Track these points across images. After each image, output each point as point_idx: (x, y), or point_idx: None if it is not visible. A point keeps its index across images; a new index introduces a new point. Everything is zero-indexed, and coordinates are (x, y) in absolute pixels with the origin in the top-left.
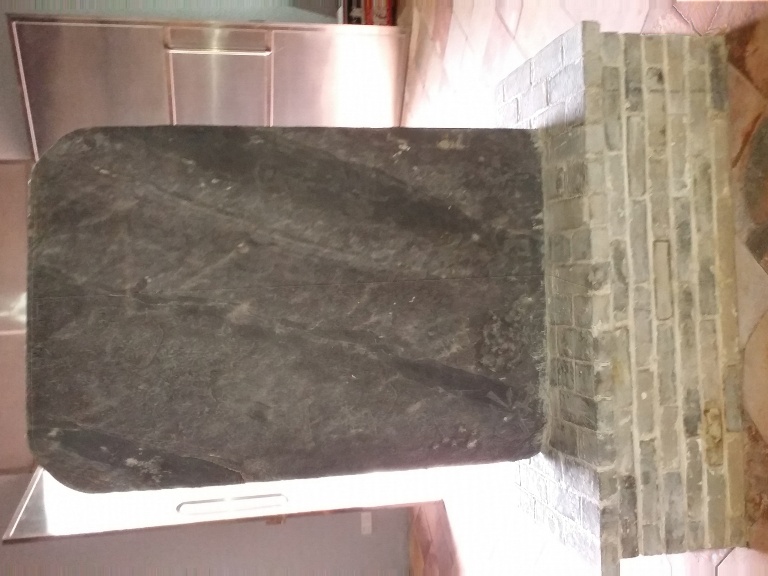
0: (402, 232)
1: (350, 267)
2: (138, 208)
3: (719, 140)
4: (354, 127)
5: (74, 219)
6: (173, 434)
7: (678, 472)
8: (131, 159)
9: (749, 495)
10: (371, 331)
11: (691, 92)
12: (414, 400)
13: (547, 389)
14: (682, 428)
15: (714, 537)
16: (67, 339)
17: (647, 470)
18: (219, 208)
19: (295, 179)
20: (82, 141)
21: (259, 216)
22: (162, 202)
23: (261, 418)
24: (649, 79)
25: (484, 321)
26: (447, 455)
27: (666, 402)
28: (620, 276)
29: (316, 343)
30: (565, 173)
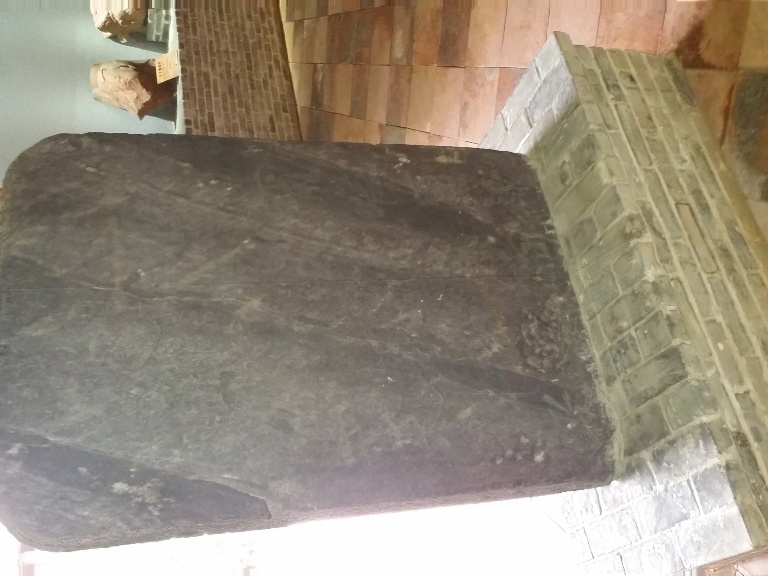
0: (416, 233)
1: (368, 265)
2: (129, 204)
3: (700, 127)
4: None
5: (55, 211)
6: (175, 450)
7: None
8: (121, 160)
9: None
10: (401, 329)
11: (662, 91)
12: (463, 405)
13: (605, 392)
14: None
15: None
16: (40, 335)
17: (754, 426)
18: (220, 206)
19: (298, 183)
20: (67, 142)
21: (264, 215)
22: (156, 199)
23: (286, 428)
24: (623, 79)
25: (520, 320)
26: (514, 471)
27: (745, 353)
28: (655, 232)
29: (341, 342)
30: (569, 161)
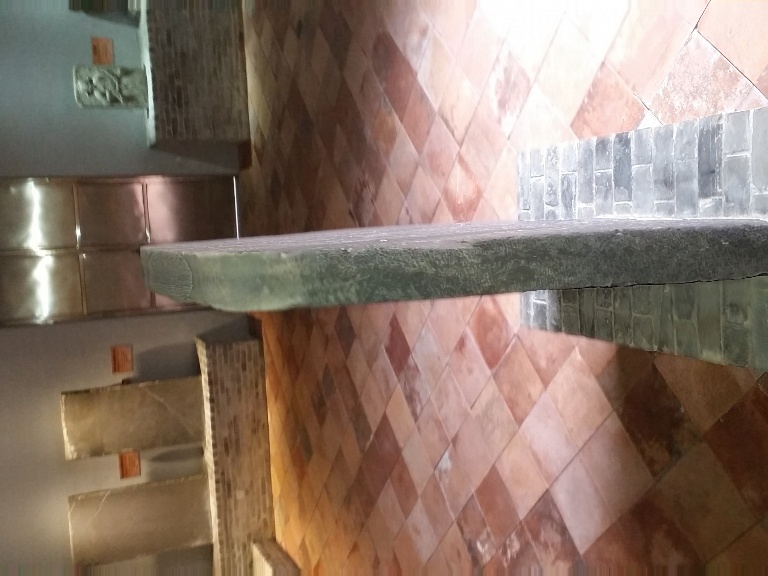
0: None
1: None
2: None
3: None
4: (614, 286)
5: None
6: None
7: None
8: None
9: None
10: None
11: None
12: None
13: None
14: None
15: None
16: None
17: None
18: None
19: None
20: None
21: None
22: None
23: None
24: None
25: None
26: None
27: None
28: None
29: None
30: (742, 326)
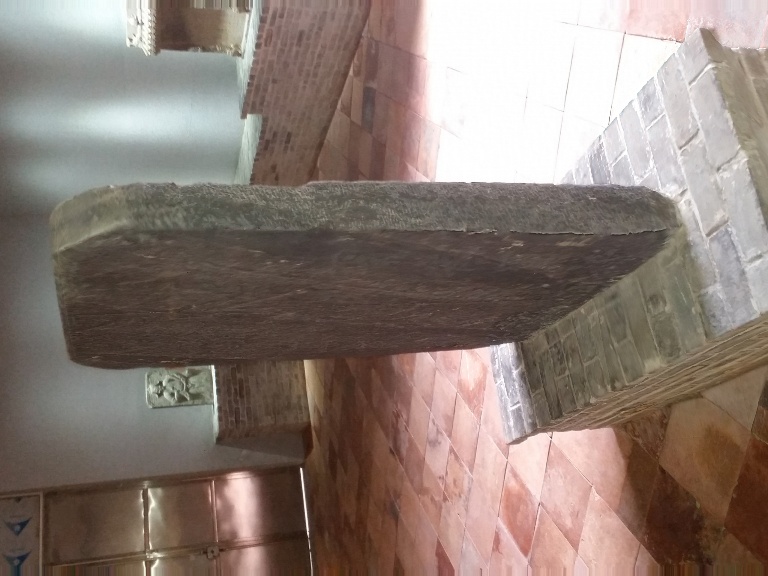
0: (474, 284)
1: (407, 298)
2: (189, 274)
3: None
4: (470, 231)
5: (112, 282)
6: None
7: None
8: (185, 249)
9: (635, 424)
10: (407, 319)
11: None
12: None
13: (540, 332)
14: None
15: None
16: (106, 329)
17: None
18: (283, 274)
19: (379, 259)
20: (121, 239)
21: (327, 277)
22: (218, 272)
23: None
24: None
25: (515, 314)
26: (434, 349)
27: None
28: None
29: (351, 324)
30: (664, 313)
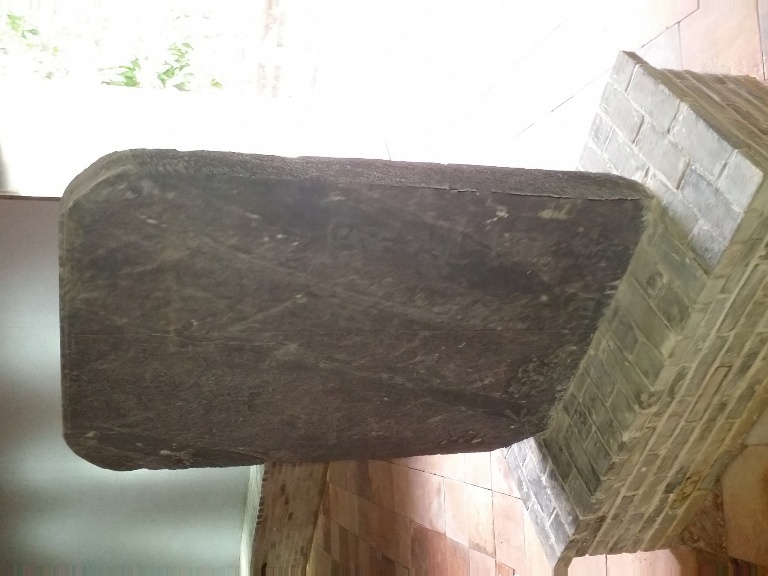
0: (472, 291)
1: (409, 318)
2: (189, 258)
3: None
4: (453, 189)
5: (115, 267)
6: (206, 435)
7: (643, 513)
8: (185, 209)
9: (690, 528)
10: (413, 367)
11: None
12: (436, 415)
13: (558, 409)
14: (663, 489)
15: (648, 546)
16: (105, 368)
17: (619, 512)
18: (281, 262)
19: (372, 238)
20: (126, 187)
21: (324, 271)
22: (218, 254)
23: (291, 425)
24: None
25: (524, 362)
26: (452, 447)
27: (659, 473)
28: (671, 393)
29: (357, 375)
30: (663, 285)
